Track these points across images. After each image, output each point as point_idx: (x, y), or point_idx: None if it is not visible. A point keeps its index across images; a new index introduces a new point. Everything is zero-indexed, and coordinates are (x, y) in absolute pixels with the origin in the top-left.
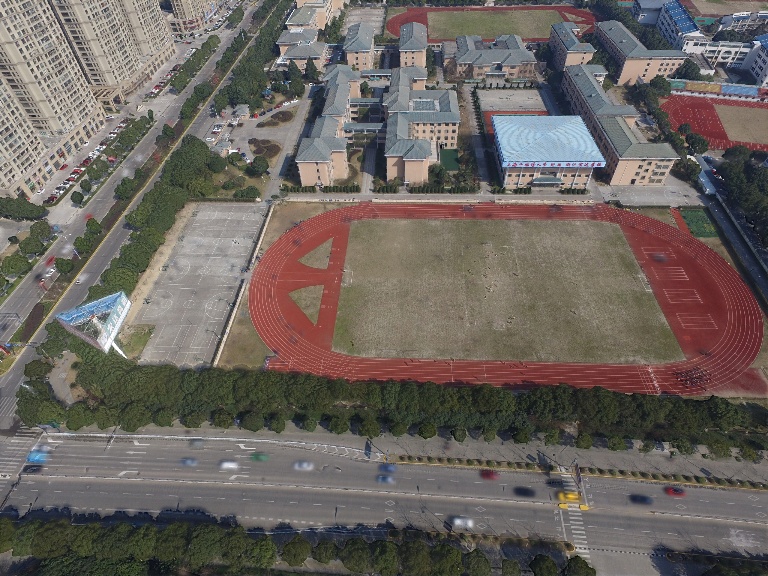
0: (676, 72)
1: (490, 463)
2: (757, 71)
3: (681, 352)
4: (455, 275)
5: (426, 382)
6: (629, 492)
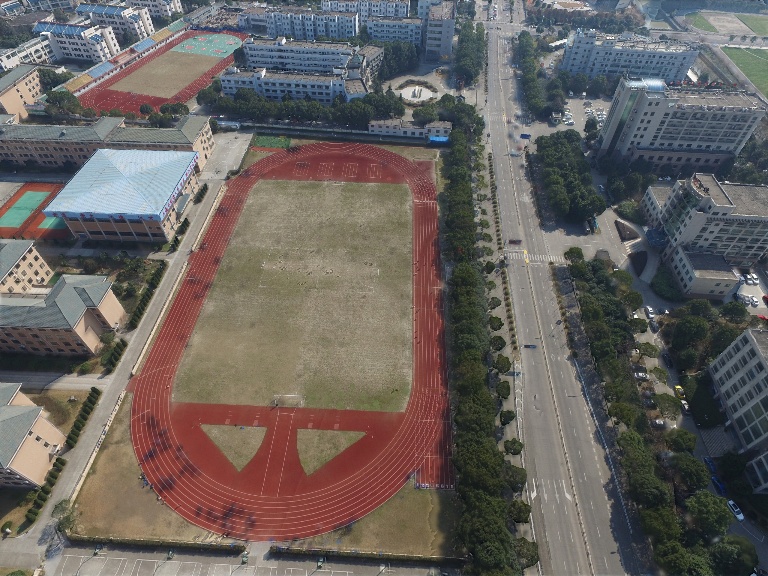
0: (42, 84)
1: (508, 292)
2: (76, 53)
3: (402, 184)
4: (304, 296)
5: (458, 314)
6: (510, 231)
